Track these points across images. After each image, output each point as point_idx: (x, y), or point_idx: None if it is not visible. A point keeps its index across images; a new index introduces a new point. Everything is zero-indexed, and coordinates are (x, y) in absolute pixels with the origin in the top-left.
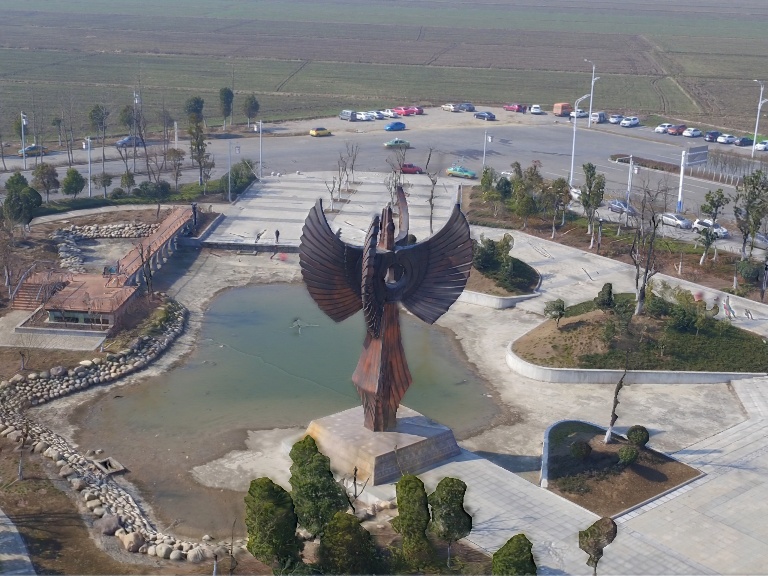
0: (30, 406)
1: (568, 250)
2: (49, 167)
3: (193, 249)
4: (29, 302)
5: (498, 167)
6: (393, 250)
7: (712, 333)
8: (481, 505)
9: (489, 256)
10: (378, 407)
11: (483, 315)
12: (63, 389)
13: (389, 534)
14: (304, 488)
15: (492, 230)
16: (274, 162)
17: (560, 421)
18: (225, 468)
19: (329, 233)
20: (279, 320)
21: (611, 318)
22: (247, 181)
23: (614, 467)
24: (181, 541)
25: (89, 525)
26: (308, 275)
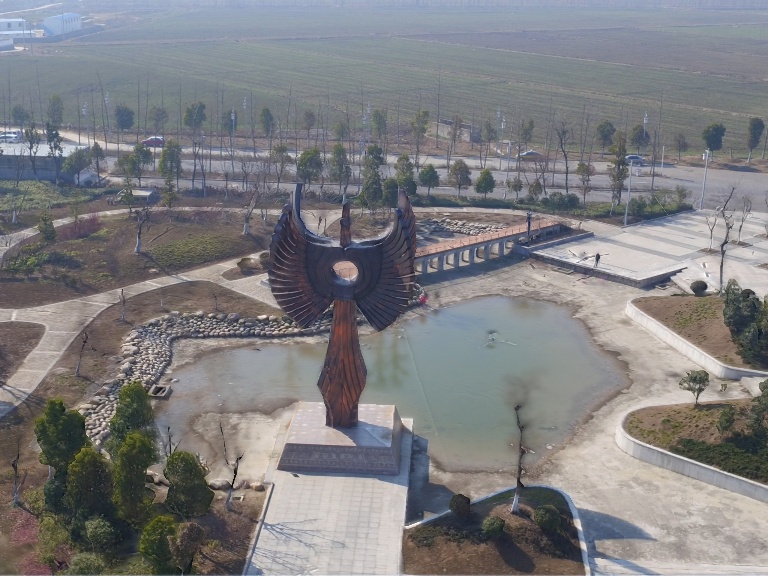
0: (189, 337)
1: None
2: (463, 164)
3: (520, 257)
4: None
5: None
6: (345, 246)
7: None
8: (324, 517)
9: (746, 318)
10: (326, 401)
11: None
12: (224, 331)
13: None
14: None
15: None
16: (745, 198)
17: (541, 485)
18: (227, 421)
19: (296, 219)
20: (490, 331)
21: (766, 410)
22: (673, 210)
23: (476, 534)
24: None
25: None
26: None
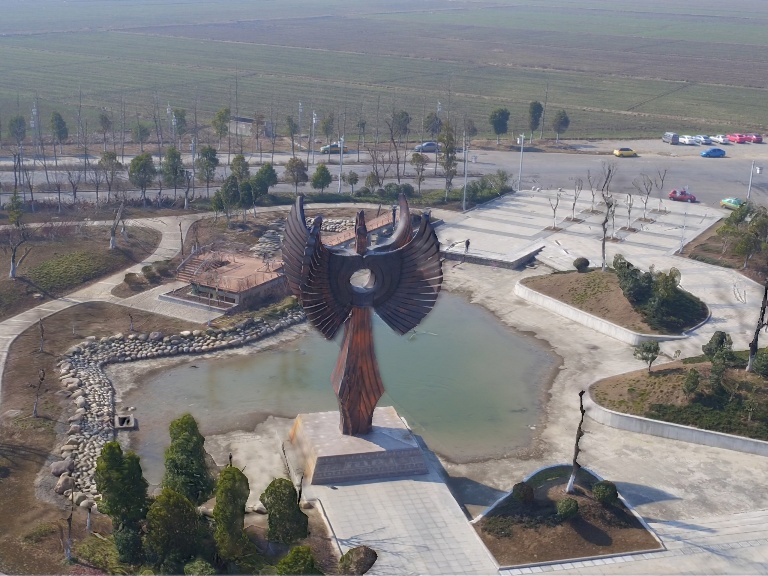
0: (116, 361)
1: None
2: (299, 161)
3: None
4: (191, 275)
5: None
6: (363, 254)
7: None
8: (390, 524)
9: (644, 289)
10: (345, 410)
11: (611, 349)
12: (152, 352)
13: None
14: (168, 462)
15: (706, 266)
16: (549, 177)
17: (562, 464)
18: (216, 443)
19: (304, 230)
20: None
21: None
22: (498, 192)
23: (550, 517)
24: None
25: (48, 464)
26: (288, 269)
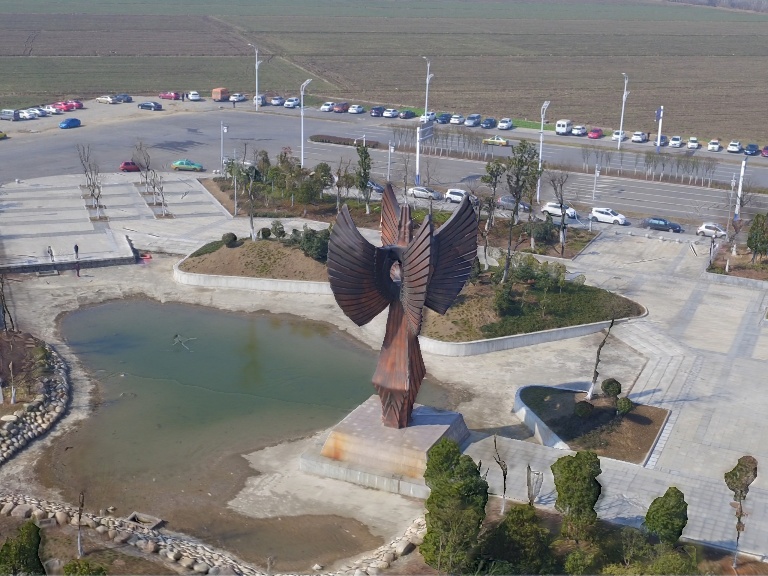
0: None
1: (363, 231)
2: None
3: None
4: None
5: (214, 157)
6: None
7: (570, 290)
8: None
9: (326, 245)
10: (404, 404)
11: None
12: (5, 452)
13: (494, 520)
14: None
15: None
16: None
17: (520, 389)
18: (260, 496)
19: (360, 237)
20: (151, 339)
21: (485, 289)
22: None
23: (616, 419)
24: (310, 575)
25: None
26: (337, 282)
